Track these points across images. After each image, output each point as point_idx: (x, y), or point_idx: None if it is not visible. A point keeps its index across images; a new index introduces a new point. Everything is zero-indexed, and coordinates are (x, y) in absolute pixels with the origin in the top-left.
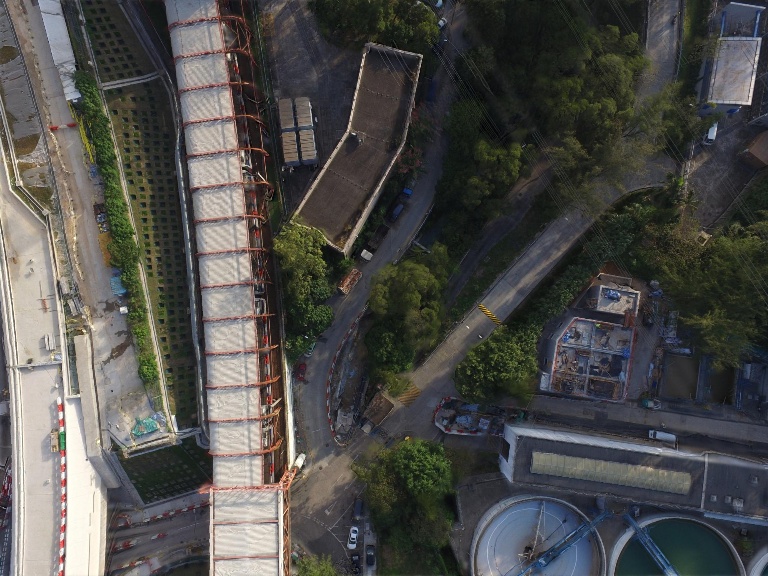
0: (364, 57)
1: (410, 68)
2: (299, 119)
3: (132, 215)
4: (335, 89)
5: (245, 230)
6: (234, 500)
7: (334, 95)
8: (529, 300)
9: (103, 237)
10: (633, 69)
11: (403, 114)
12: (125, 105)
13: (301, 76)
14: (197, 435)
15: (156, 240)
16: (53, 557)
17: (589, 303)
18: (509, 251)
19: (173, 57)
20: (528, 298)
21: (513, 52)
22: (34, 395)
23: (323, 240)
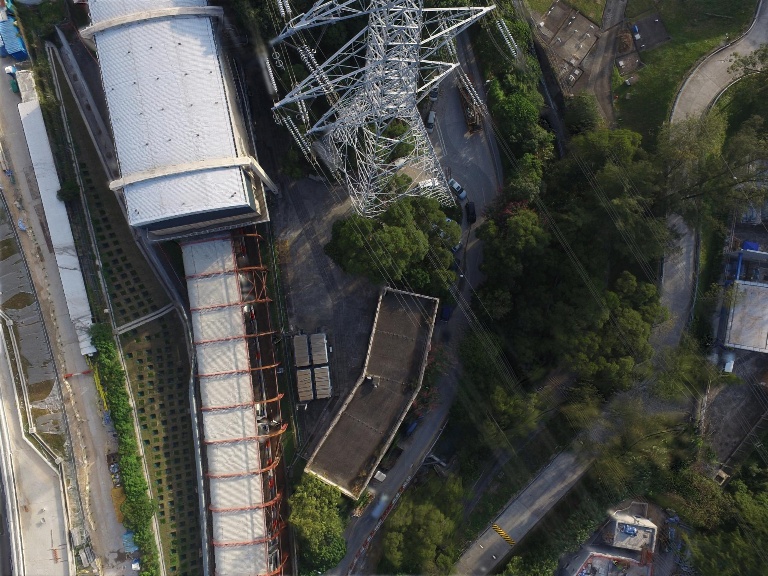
0: (380, 300)
1: (426, 309)
2: (314, 357)
3: (145, 462)
4: (350, 317)
5: (259, 485)
6: None
7: (349, 322)
8: (544, 524)
9: (116, 493)
10: (650, 321)
11: (419, 356)
12: (140, 346)
13: (316, 303)
14: None
15: (169, 483)
16: None
17: (605, 538)
18: (523, 469)
19: None
20: (543, 521)
21: (530, 298)
22: None
23: (338, 492)
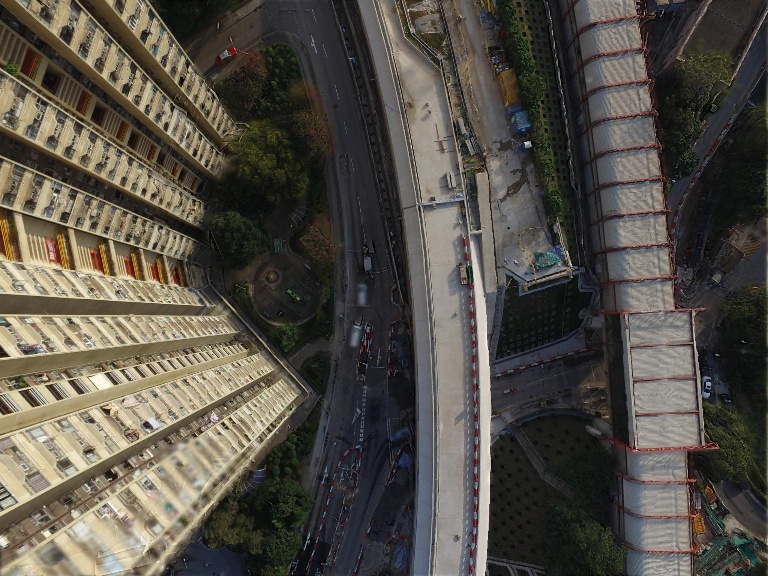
0: None
1: None
2: None
3: None
4: None
5: (643, 63)
6: (648, 324)
7: None
8: None
9: (507, 74)
10: None
11: None
12: None
13: None
14: (579, 275)
15: None
16: (466, 386)
17: None
18: None
19: None
20: None
21: None
22: (437, 232)
23: None
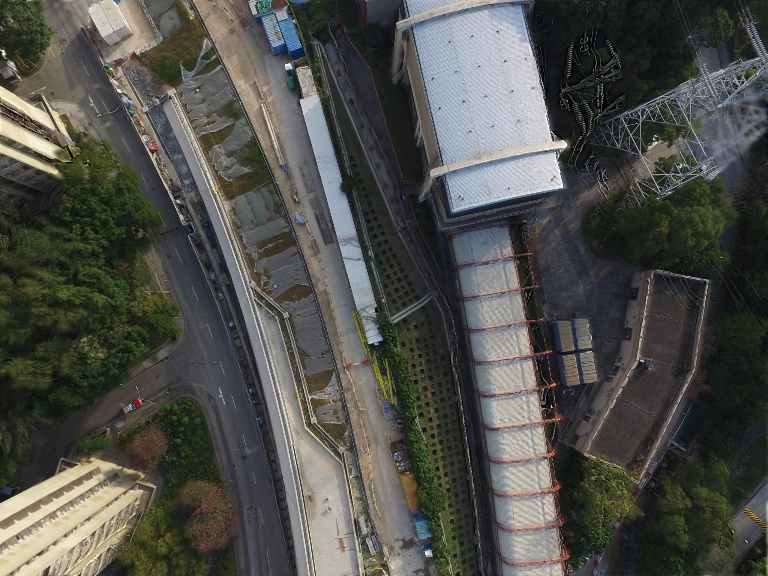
0: (649, 283)
1: (693, 291)
2: (579, 342)
3: None
4: (602, 302)
5: (547, 469)
6: None
7: (601, 307)
8: None
9: (407, 480)
10: None
11: (689, 338)
12: (410, 335)
13: (568, 289)
14: None
15: (445, 471)
16: None
17: None
18: None
19: (461, 290)
20: None
21: None
22: None
23: None
